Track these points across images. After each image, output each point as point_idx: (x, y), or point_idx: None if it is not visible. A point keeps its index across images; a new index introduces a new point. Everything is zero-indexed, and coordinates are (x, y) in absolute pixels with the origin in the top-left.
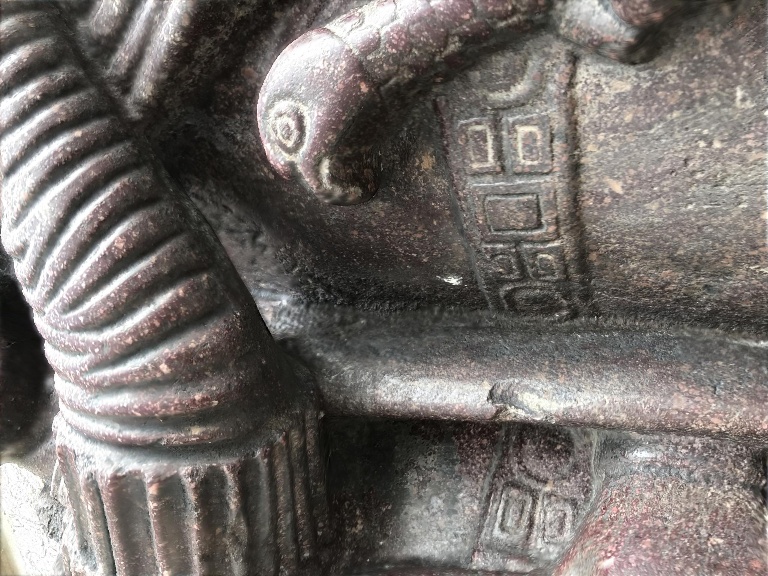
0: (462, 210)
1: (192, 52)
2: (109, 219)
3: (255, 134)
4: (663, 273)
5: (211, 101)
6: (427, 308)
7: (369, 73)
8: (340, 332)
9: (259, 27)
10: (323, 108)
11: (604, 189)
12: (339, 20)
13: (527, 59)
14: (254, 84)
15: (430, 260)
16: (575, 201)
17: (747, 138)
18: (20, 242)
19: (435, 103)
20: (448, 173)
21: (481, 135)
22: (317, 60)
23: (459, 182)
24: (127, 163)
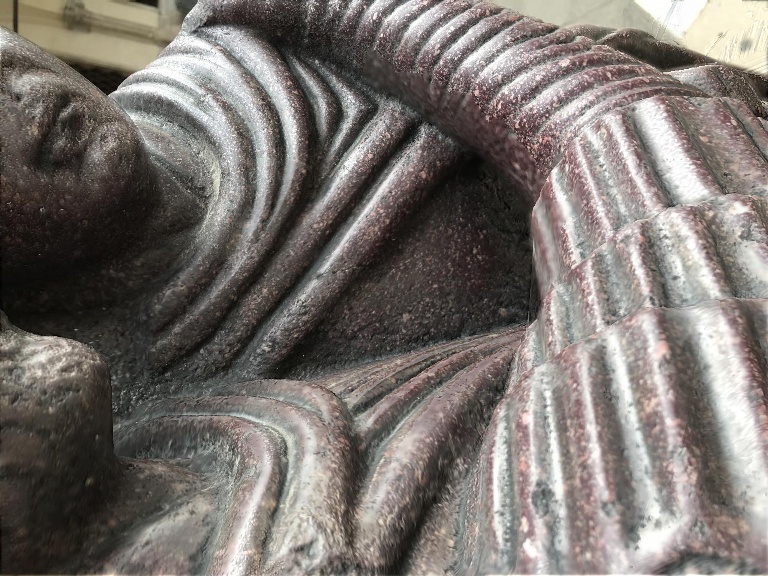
0: None
1: None
2: None
3: None
4: None
5: None
6: None
7: None
8: None
9: None
10: None
11: None
12: None
13: None
14: None
15: None
16: None
17: None
18: (550, 25)
19: None
20: None
21: None
22: None
23: None
24: None
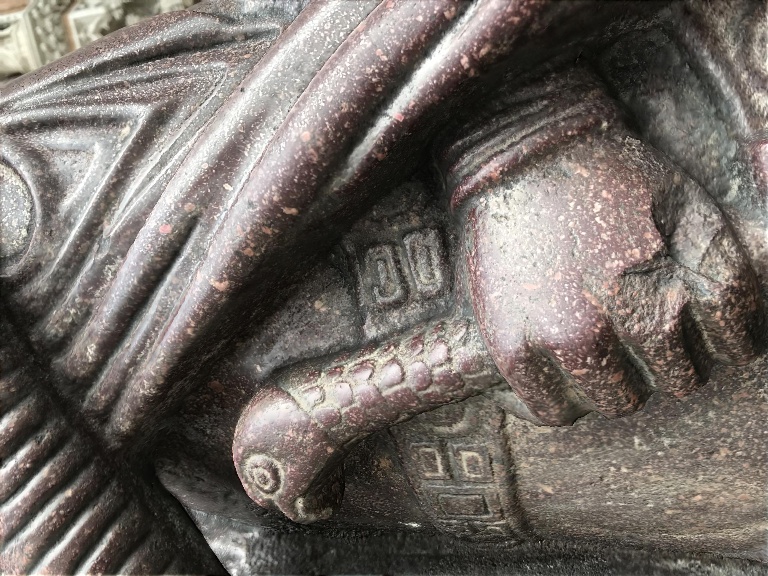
0: (419, 499)
1: (165, 394)
2: (106, 573)
3: (223, 429)
4: (593, 529)
5: (181, 408)
6: (390, 534)
7: (333, 440)
8: (313, 569)
9: (223, 356)
10: (295, 466)
11: (538, 490)
12: (302, 389)
13: (464, 407)
14: (220, 393)
15: (391, 515)
16: (515, 497)
17: (647, 468)
18: None
19: (388, 430)
20: (404, 474)
21: (431, 455)
22: (287, 429)
23: (415, 483)
24: (115, 508)
